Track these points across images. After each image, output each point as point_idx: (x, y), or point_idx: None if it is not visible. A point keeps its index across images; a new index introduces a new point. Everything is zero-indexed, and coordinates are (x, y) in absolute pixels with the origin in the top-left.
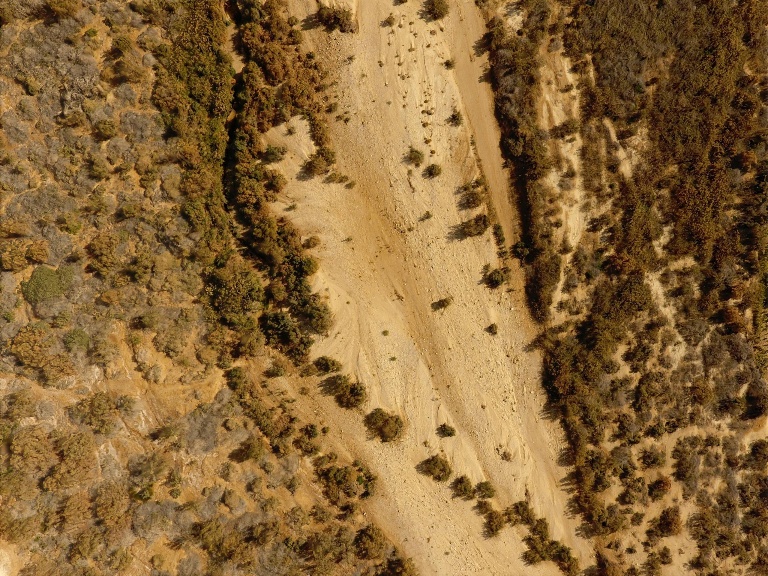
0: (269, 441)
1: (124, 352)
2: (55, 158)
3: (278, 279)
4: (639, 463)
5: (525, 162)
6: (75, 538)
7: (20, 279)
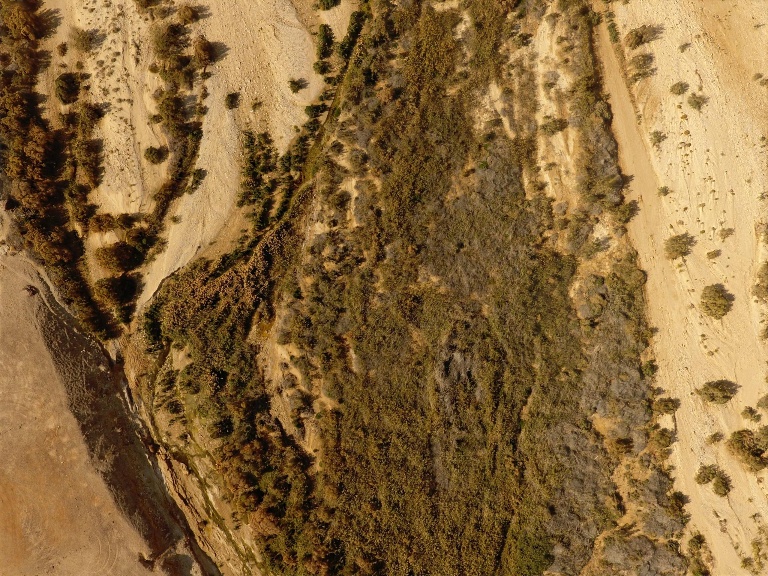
0: None
1: None
2: None
3: None
4: None
5: None
6: None
7: None
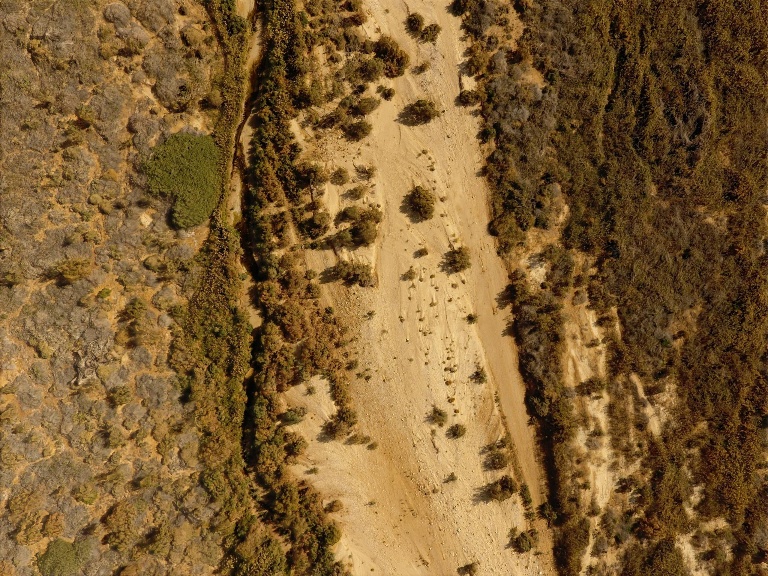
0: None
1: None
2: (70, 428)
3: (300, 545)
4: None
5: (551, 425)
6: None
7: (35, 550)
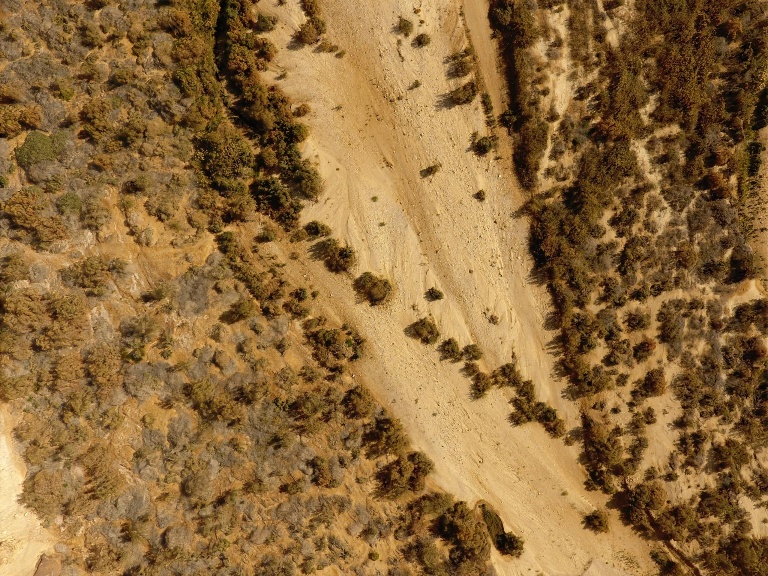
0: (259, 304)
1: (116, 217)
2: (48, 25)
3: (269, 147)
4: (624, 326)
5: (513, 30)
6: (67, 396)
7: (14, 145)
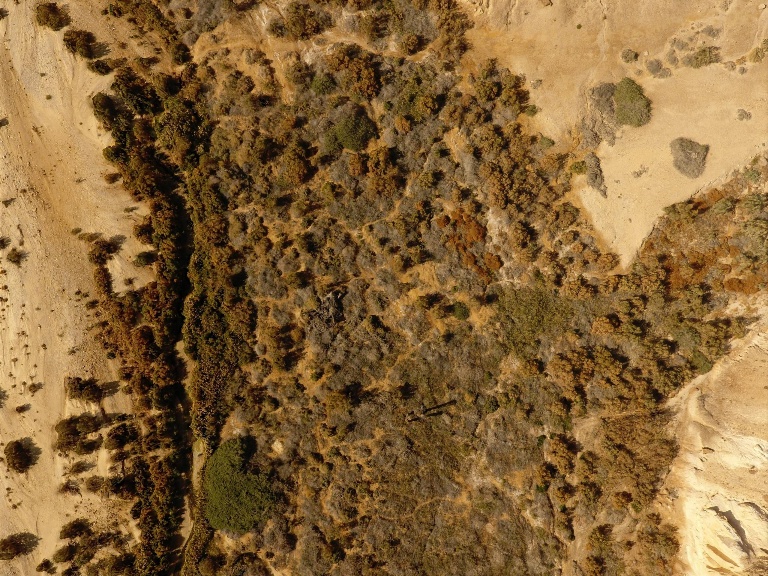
0: (152, 1)
1: (282, 76)
2: (344, 252)
3: None
4: None
5: None
6: None
7: (380, 141)
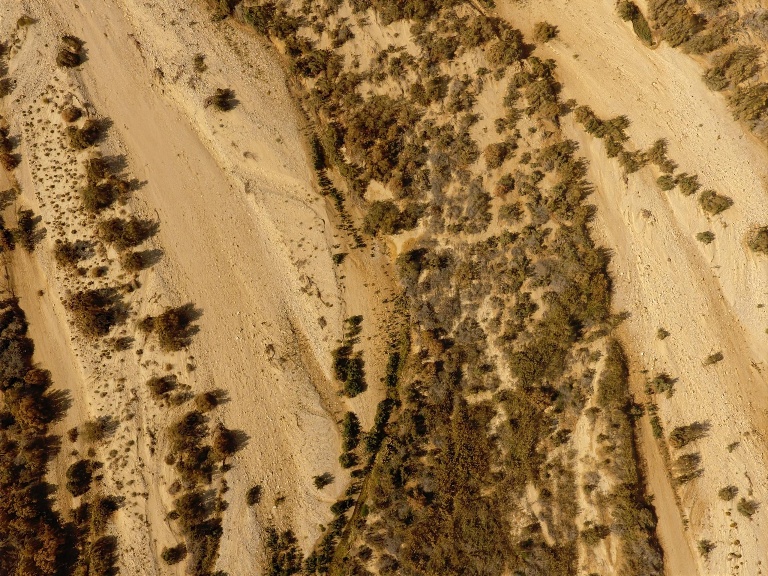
0: None
1: None
2: None
3: None
4: (523, 209)
5: None
6: None
7: None
